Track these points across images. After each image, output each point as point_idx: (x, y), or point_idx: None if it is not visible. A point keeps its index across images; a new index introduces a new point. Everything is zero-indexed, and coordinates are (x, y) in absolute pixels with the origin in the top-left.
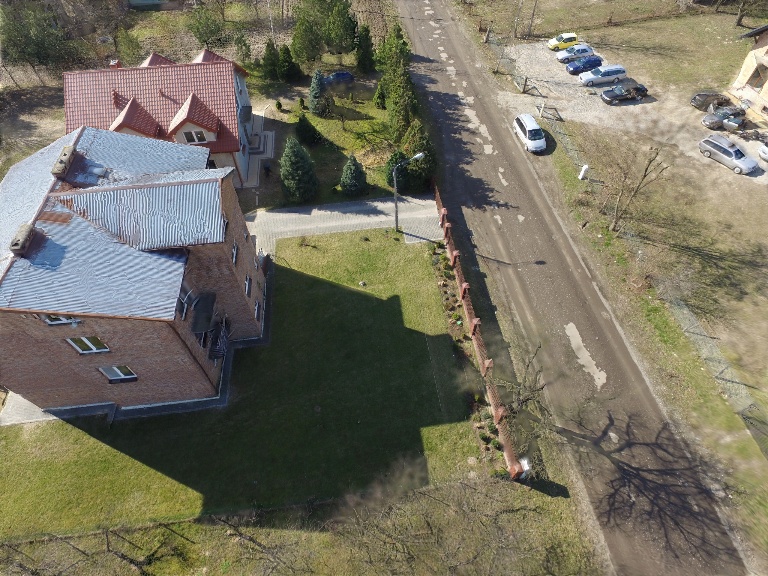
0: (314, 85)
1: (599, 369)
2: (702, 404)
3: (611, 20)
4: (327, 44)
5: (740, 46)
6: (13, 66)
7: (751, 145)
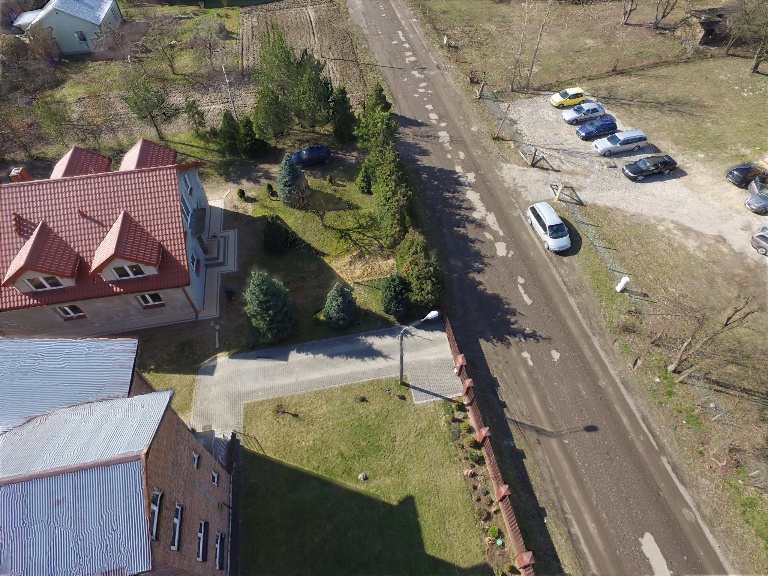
0: (284, 172)
1: None
2: None
3: (616, 68)
4: (297, 116)
5: (762, 99)
6: None
7: None
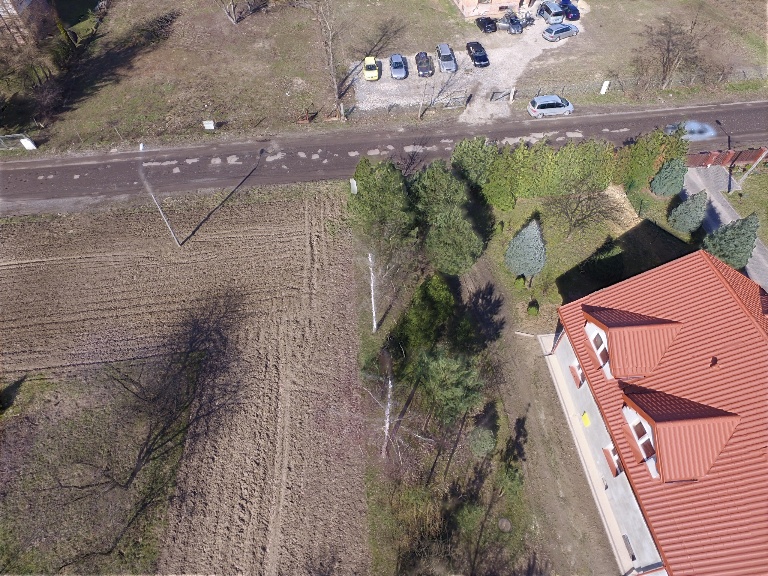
0: None
1: None
2: None
3: None
4: None
5: (386, 1)
6: None
7: (538, 24)
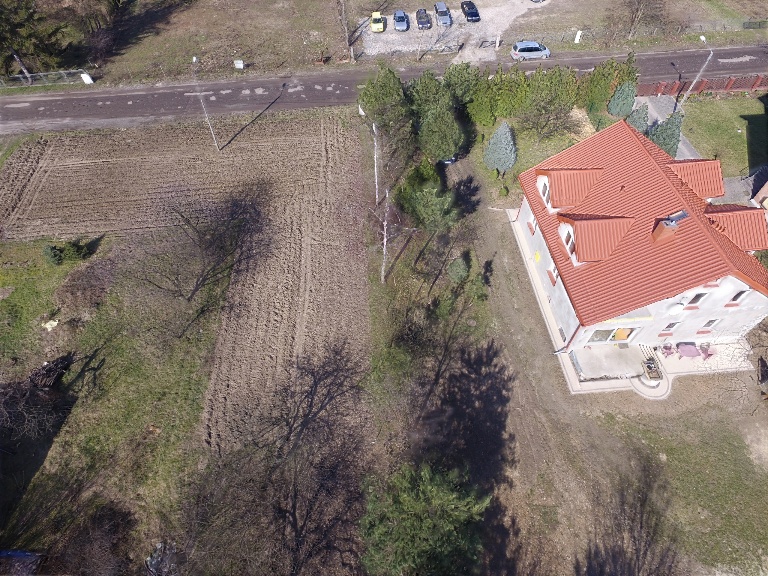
0: None
1: (745, 56)
2: (744, 36)
3: None
4: None
5: None
6: None
7: None
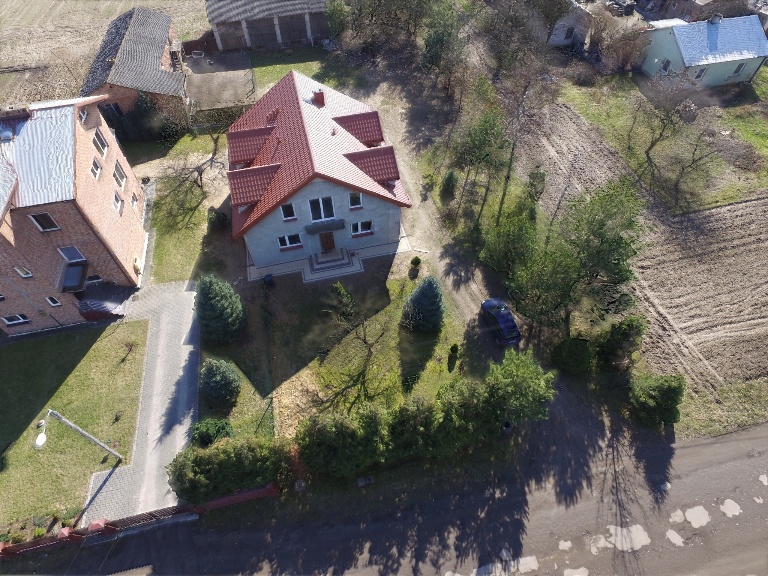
0: (418, 285)
1: None
2: None
3: None
4: None
5: None
6: (476, 49)
7: None
